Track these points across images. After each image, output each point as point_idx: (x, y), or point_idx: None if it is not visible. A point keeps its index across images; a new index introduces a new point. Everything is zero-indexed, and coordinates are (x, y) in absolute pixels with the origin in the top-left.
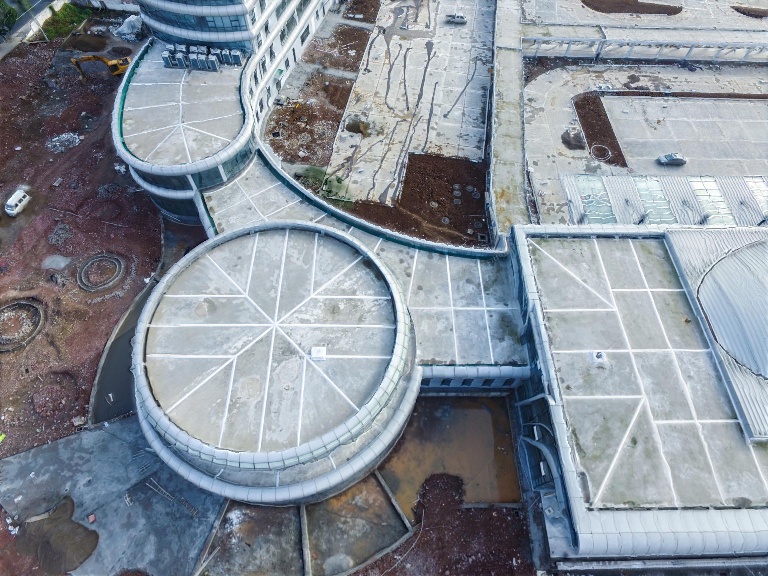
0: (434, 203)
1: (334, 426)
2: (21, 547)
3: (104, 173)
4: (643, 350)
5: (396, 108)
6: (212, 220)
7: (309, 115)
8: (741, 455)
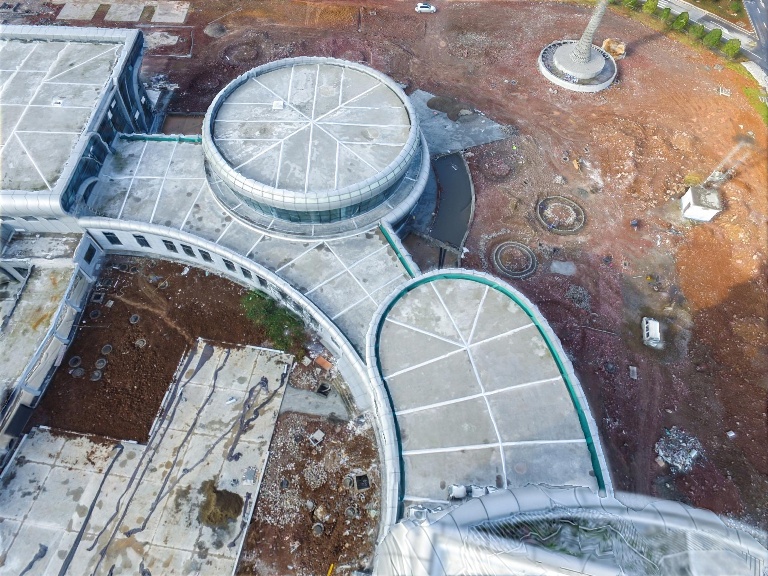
0: (140, 344)
1: (271, 73)
2: (469, 105)
3: (585, 389)
4: (17, 105)
5: (135, 574)
6: (404, 264)
7: (308, 543)
8: (4, 57)
